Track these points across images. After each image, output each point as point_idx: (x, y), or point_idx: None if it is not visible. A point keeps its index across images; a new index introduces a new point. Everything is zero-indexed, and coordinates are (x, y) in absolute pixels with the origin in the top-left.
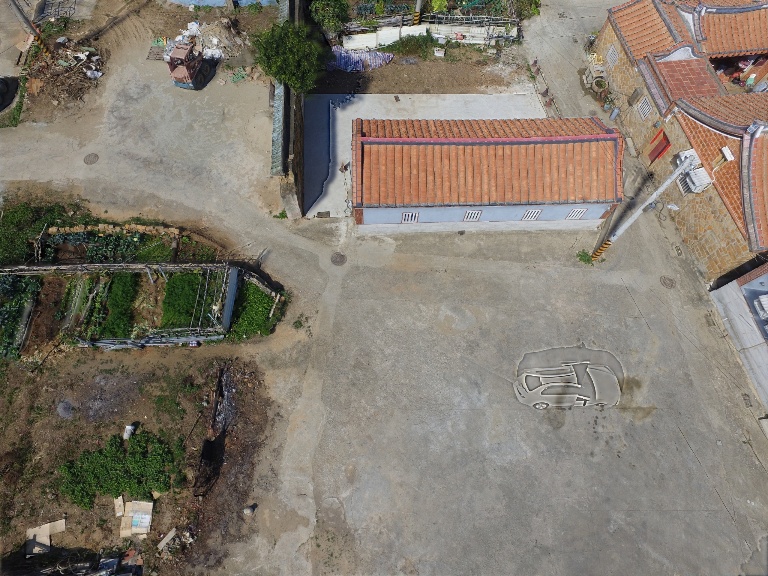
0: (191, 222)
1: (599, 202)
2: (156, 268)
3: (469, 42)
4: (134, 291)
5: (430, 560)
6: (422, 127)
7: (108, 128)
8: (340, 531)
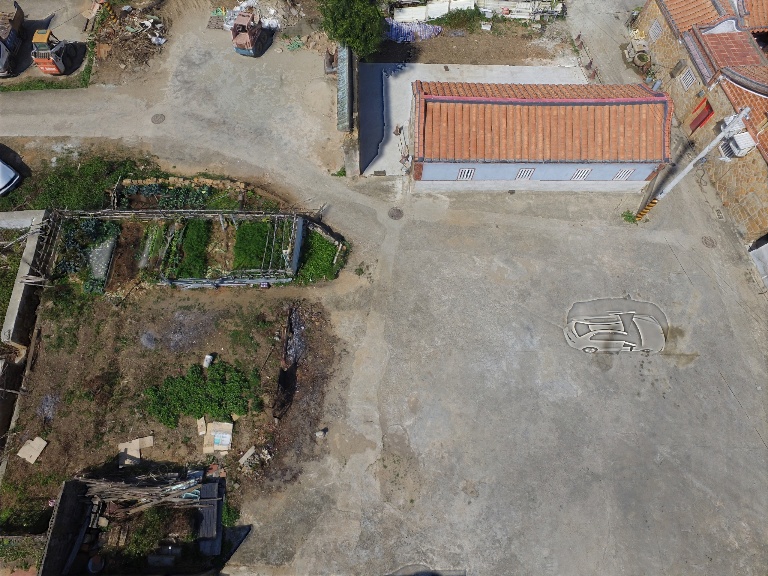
0: (254, 178)
1: (647, 162)
2: (226, 217)
3: (514, 17)
4: (207, 237)
5: (489, 483)
6: (479, 89)
7: (173, 91)
8: (405, 455)
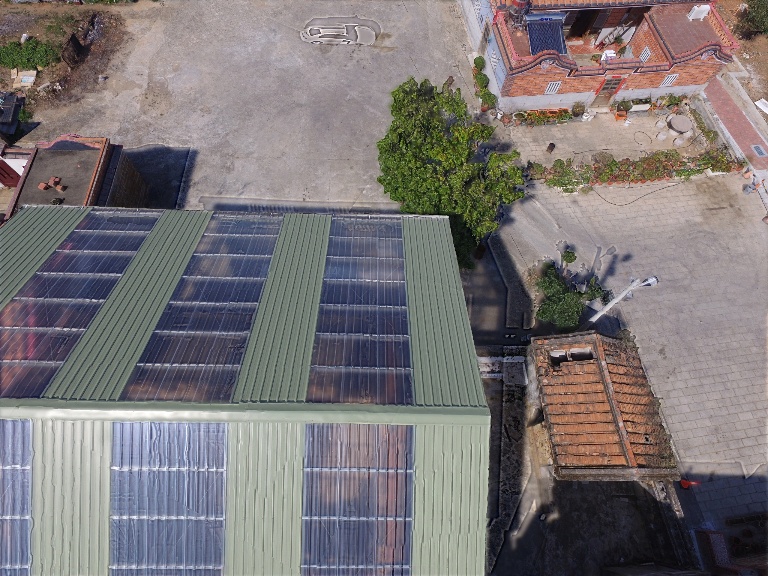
0: None
1: None
2: None
3: None
4: None
5: (221, 107)
6: None
7: None
8: (163, 92)
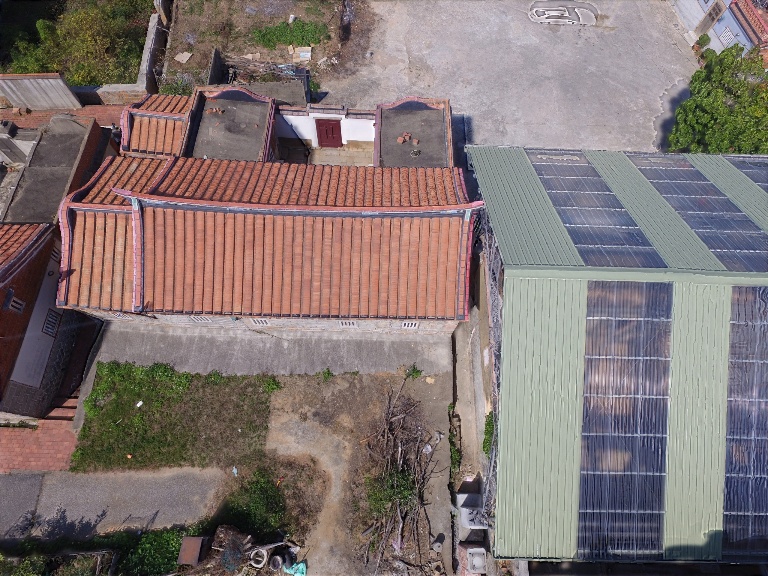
0: None
1: None
2: None
3: None
4: None
5: (478, 79)
6: None
7: None
8: (424, 66)
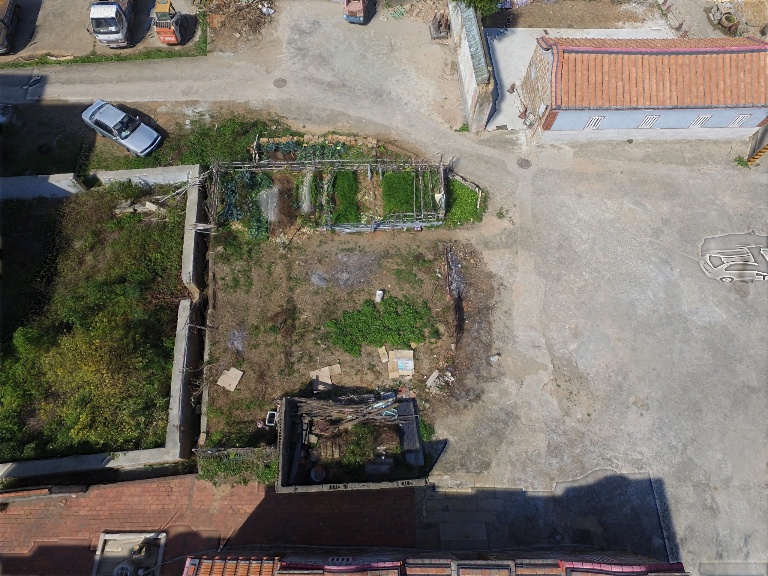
0: (382, 135)
1: (766, 106)
2: None
3: None
4: (356, 186)
5: (656, 397)
6: (602, 43)
7: (289, 57)
8: (575, 375)
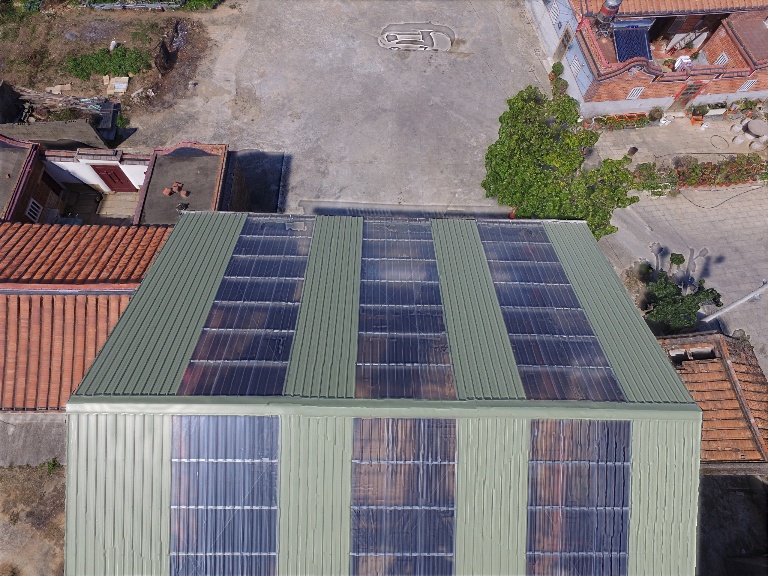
0: None
1: None
2: None
3: None
4: None
5: (309, 112)
6: None
7: None
8: (251, 98)
